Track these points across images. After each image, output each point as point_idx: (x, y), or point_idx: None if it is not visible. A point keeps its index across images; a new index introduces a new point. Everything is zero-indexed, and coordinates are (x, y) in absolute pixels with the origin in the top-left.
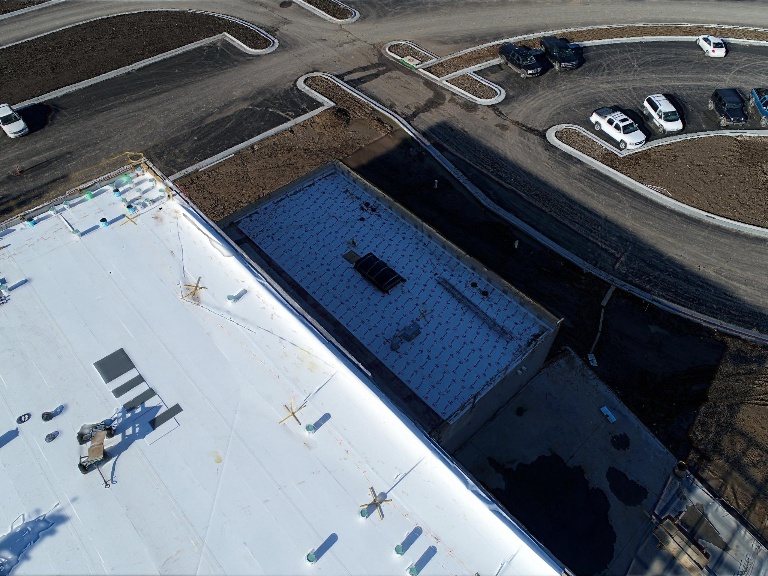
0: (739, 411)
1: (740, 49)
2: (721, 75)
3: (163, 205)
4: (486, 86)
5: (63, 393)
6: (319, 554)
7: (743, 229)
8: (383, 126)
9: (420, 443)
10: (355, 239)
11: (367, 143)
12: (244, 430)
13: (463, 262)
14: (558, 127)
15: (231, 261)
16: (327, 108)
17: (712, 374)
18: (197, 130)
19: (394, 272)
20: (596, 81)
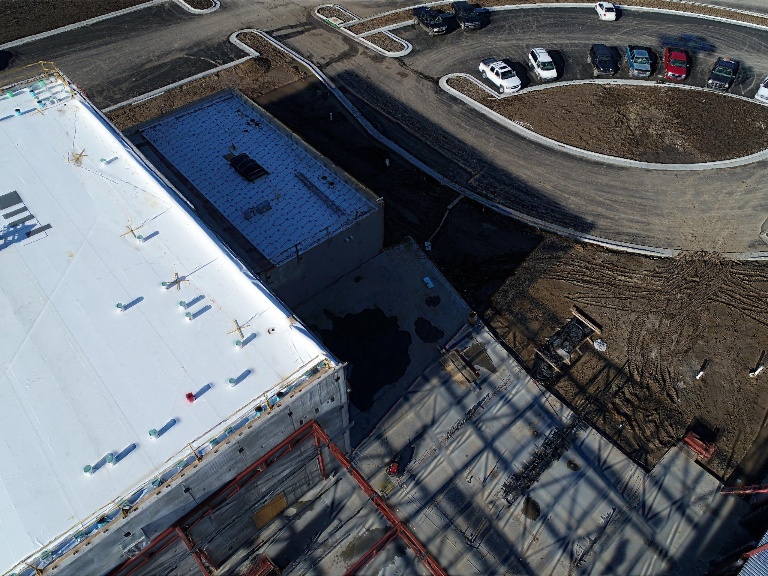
0: (536, 283)
1: (633, 15)
2: (608, 35)
3: (67, 102)
4: (396, 42)
5: None
6: (128, 307)
7: (587, 155)
8: (298, 72)
9: (216, 246)
10: (236, 145)
11: (281, 85)
12: (94, 240)
13: (319, 161)
14: (451, 75)
15: (109, 138)
16: (252, 57)
17: (523, 258)
18: (136, 73)
19: (259, 166)
20: (495, 39)
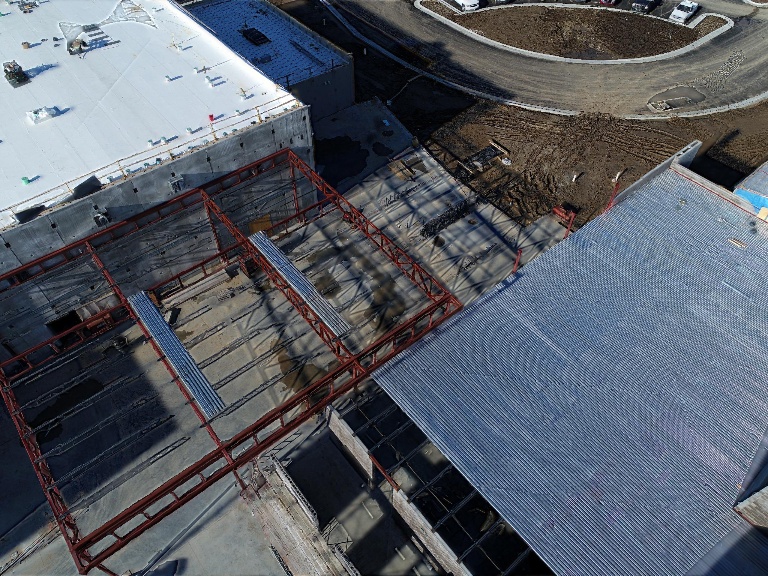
0: (467, 126)
1: None
2: None
3: None
4: None
5: None
6: (172, 79)
7: (523, 53)
8: None
9: (230, 51)
10: (248, 24)
11: (286, 2)
12: (149, 49)
13: (309, 35)
14: None
15: None
16: None
17: (460, 112)
18: None
19: (264, 35)
20: None
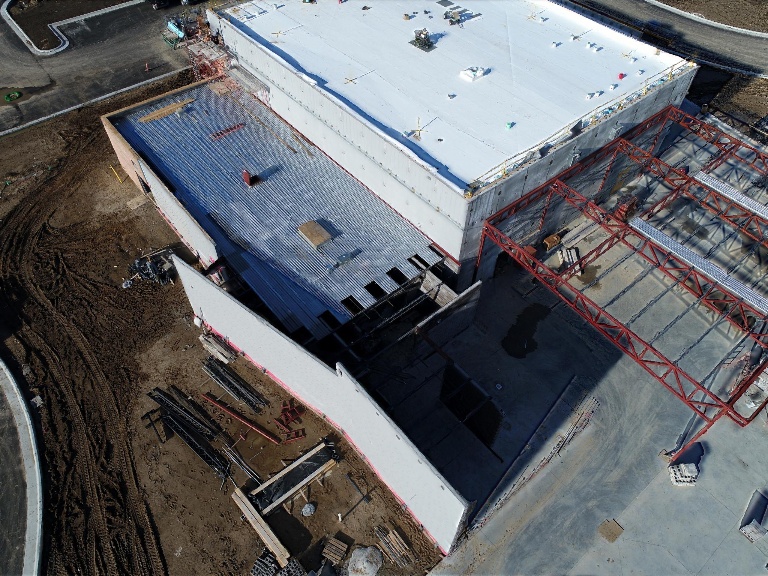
0: (738, 96)
1: None
2: None
3: None
4: None
5: (428, 8)
6: None
7: (749, 33)
8: None
9: (592, 21)
10: None
11: None
12: (512, 20)
13: (586, 13)
14: None
15: None
16: None
17: (724, 84)
18: None
19: None
20: None
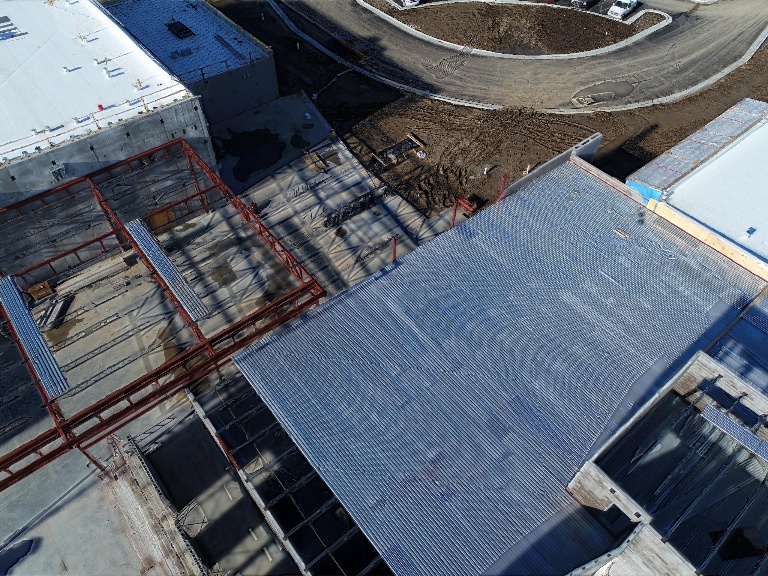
0: (388, 119)
1: None
2: None
3: None
4: None
5: None
6: (71, 70)
7: (457, 48)
8: None
9: (133, 43)
10: (175, 18)
11: None
12: (55, 41)
13: (233, 28)
14: None
15: None
16: None
17: (384, 105)
18: None
19: (188, 29)
20: None
